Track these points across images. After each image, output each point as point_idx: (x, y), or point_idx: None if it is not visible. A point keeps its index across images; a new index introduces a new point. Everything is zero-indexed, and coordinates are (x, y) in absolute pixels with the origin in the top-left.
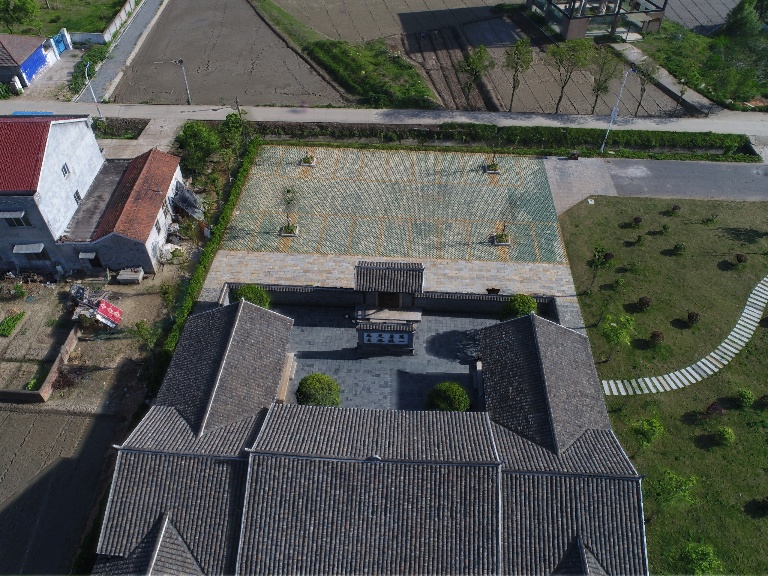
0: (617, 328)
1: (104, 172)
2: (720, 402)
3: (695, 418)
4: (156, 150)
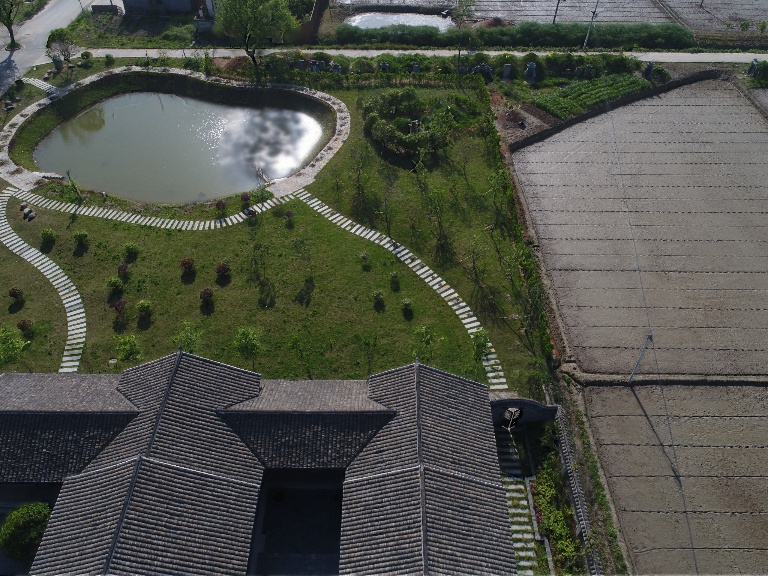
0: (5, 346)
1: None
2: (111, 302)
3: (120, 323)
4: None
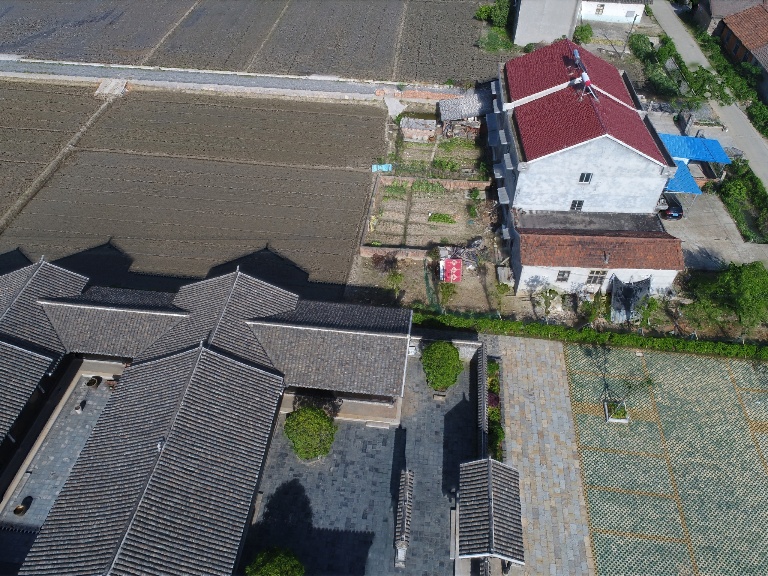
0: None
1: (635, 217)
2: None
3: None
4: (677, 242)
